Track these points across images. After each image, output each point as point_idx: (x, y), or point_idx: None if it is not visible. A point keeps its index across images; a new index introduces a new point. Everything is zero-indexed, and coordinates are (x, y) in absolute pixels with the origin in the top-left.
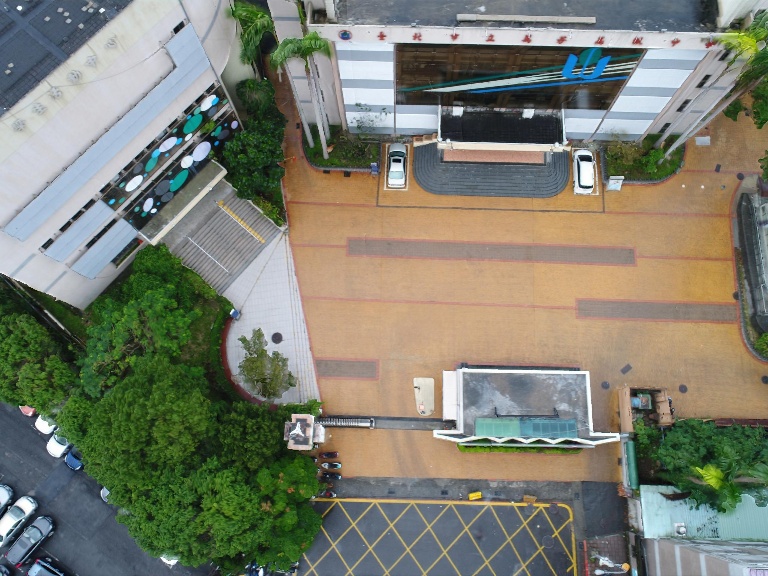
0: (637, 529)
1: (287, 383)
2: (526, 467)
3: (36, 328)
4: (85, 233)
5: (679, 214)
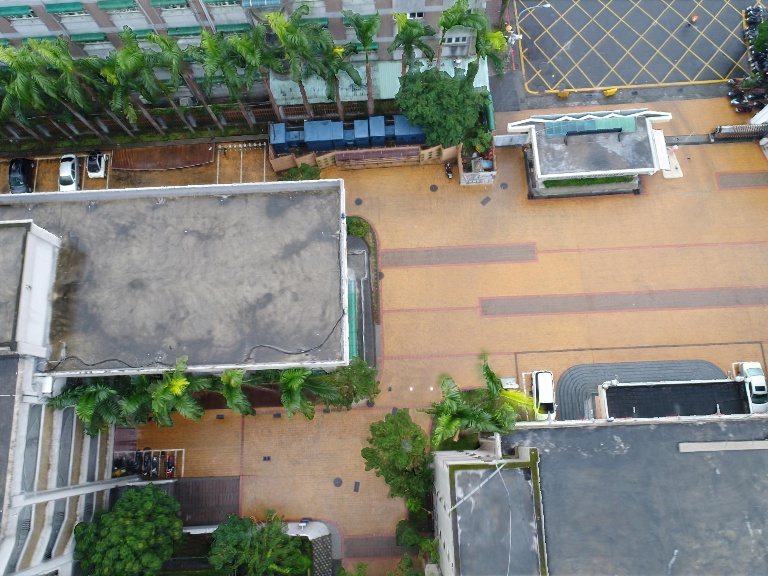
0: None
1: None
2: None
3: None
4: None
5: (436, 357)
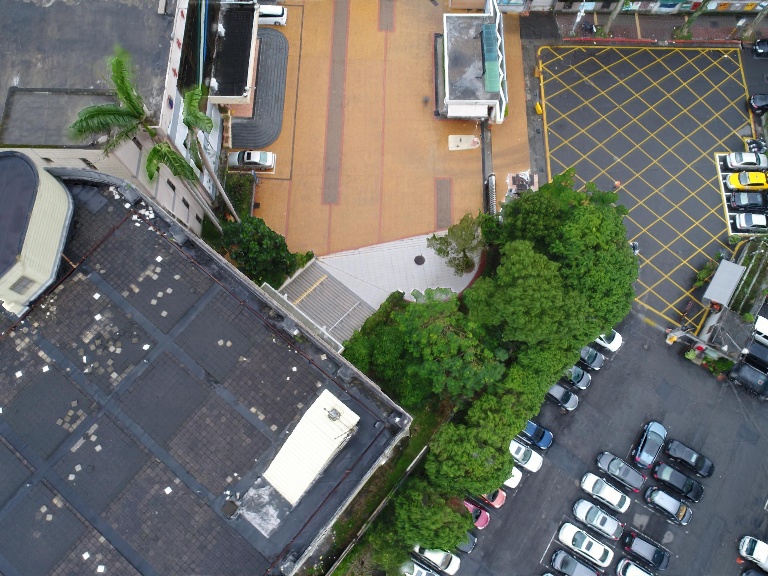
0: (551, 7)
1: None
2: (514, 74)
3: (444, 429)
4: None
5: None
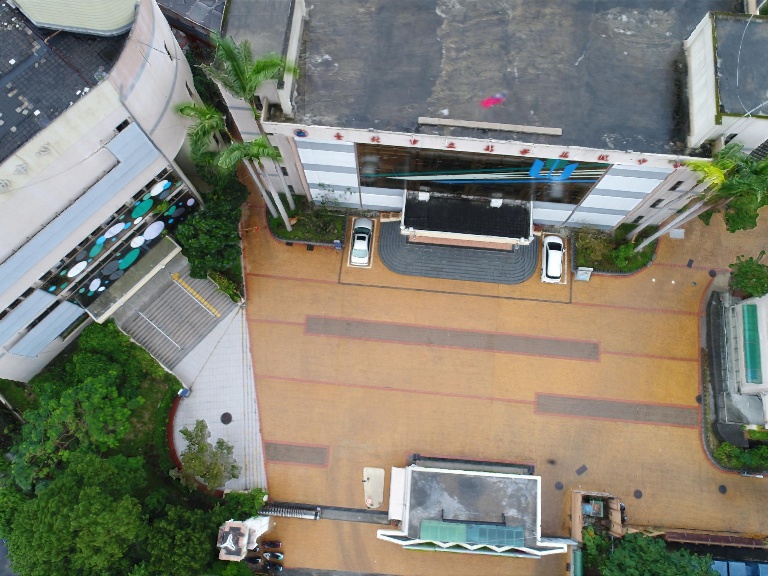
0: None
1: (230, 473)
2: (472, 567)
3: None
4: (23, 319)
5: (647, 309)
